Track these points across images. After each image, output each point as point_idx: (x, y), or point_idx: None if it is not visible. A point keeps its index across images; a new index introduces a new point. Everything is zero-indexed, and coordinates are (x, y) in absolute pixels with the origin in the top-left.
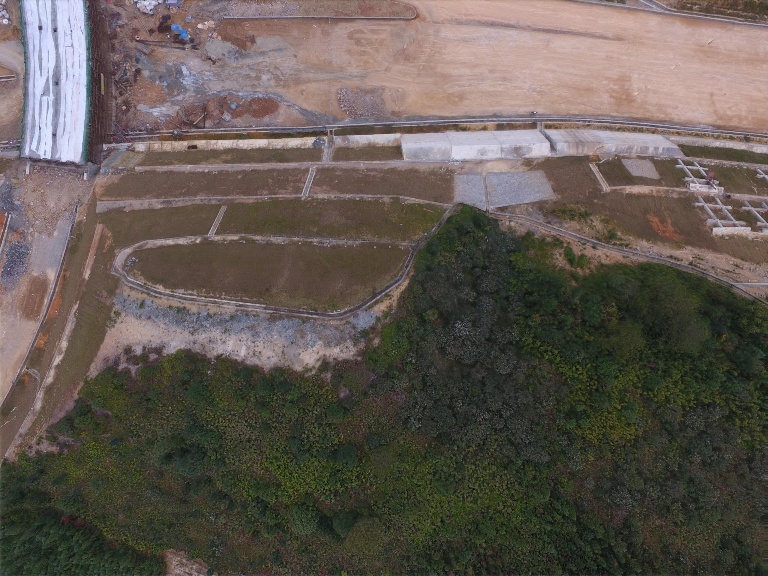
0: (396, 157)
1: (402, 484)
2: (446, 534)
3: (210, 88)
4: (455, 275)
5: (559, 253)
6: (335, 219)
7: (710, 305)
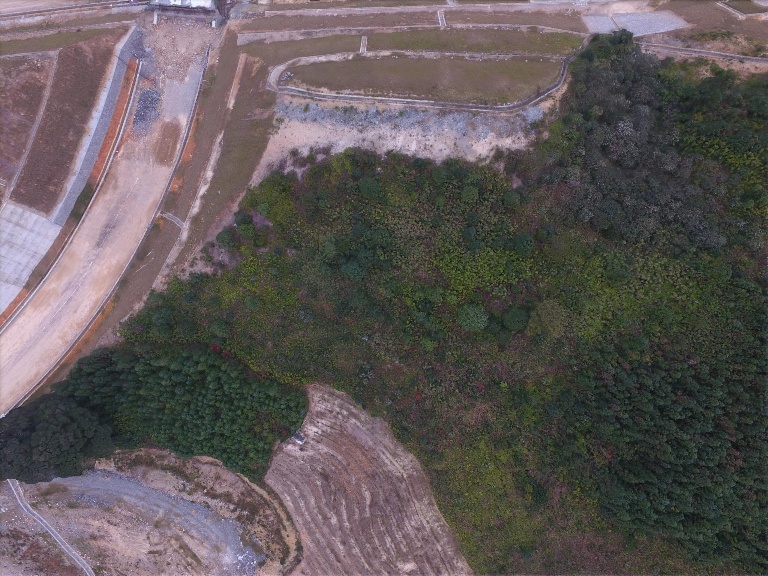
0: (522, 0)
1: (573, 277)
2: (620, 324)
3: None
4: (611, 82)
5: (705, 69)
6: (481, 40)
7: None
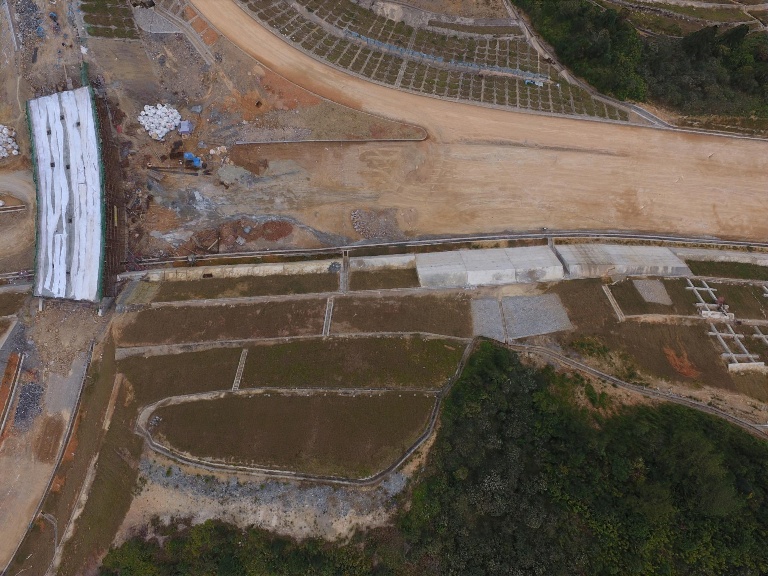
0: (413, 284)
1: None
2: None
3: (223, 212)
4: (481, 425)
5: (580, 391)
6: (358, 364)
7: (734, 458)
